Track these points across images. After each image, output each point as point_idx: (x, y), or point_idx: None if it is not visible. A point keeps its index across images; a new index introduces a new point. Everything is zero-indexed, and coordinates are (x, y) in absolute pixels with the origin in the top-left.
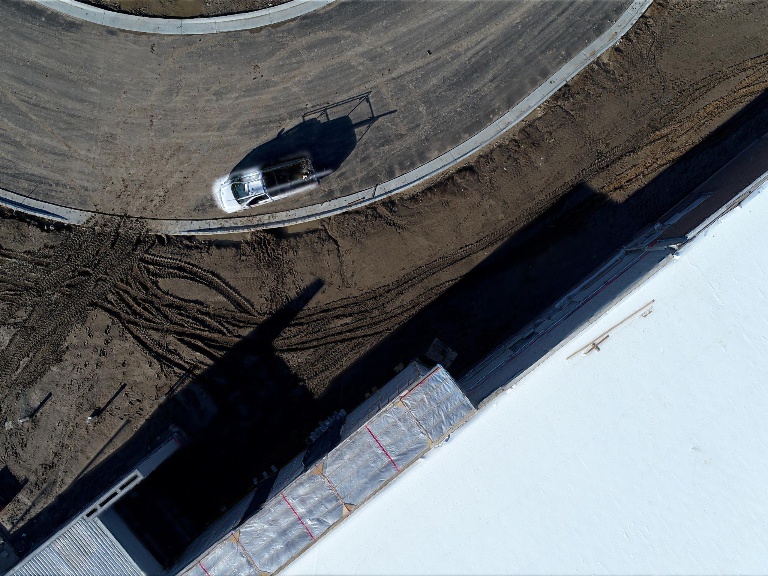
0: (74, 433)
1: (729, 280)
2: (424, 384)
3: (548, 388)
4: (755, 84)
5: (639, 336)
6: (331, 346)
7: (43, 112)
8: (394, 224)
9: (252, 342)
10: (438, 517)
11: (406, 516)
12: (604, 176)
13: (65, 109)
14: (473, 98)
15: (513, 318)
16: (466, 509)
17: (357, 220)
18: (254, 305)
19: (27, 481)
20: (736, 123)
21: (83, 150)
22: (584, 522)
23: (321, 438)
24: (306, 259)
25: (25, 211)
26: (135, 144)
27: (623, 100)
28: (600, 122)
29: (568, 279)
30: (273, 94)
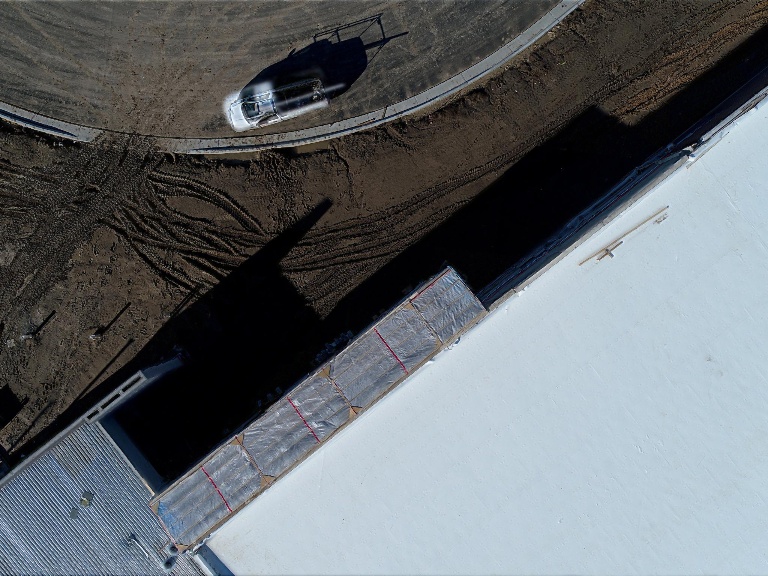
0: (77, 352)
1: (745, 187)
2: (434, 286)
3: (560, 295)
4: (767, 9)
5: (653, 243)
6: (339, 267)
7: (55, 30)
8: (404, 145)
9: (259, 262)
10: (447, 426)
11: (414, 425)
12: (616, 99)
13: (77, 27)
14: (484, 21)
15: (524, 241)
16: (476, 419)
17: (367, 141)
18: (262, 224)
19: (28, 400)
20: (749, 48)
21: (94, 68)
22: (597, 435)
23: None
24: (315, 179)
25: (34, 127)
26: (146, 62)
27: (635, 24)
28: (612, 45)
29: (579, 202)
30: (285, 15)
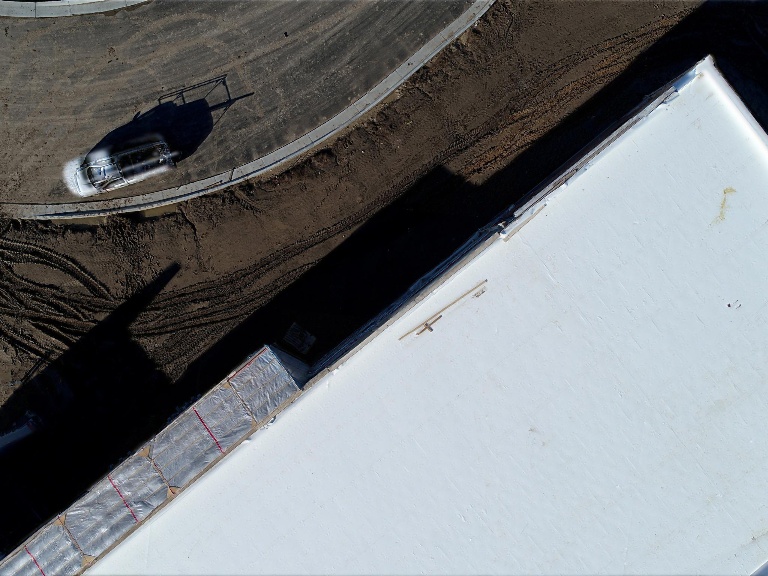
0: None
1: (563, 259)
2: (251, 365)
3: (381, 369)
4: (613, 65)
5: (473, 316)
6: (188, 331)
7: None
8: (251, 207)
9: (108, 327)
10: (271, 500)
11: (239, 499)
12: (462, 158)
13: None
14: (331, 80)
15: (372, 302)
16: (300, 492)
17: (214, 204)
18: (110, 290)
19: None
20: (595, 104)
21: None
22: (421, 505)
23: None
24: (162, 243)
25: None
26: None
27: (481, 82)
28: (458, 104)
29: (427, 262)
30: (129, 77)
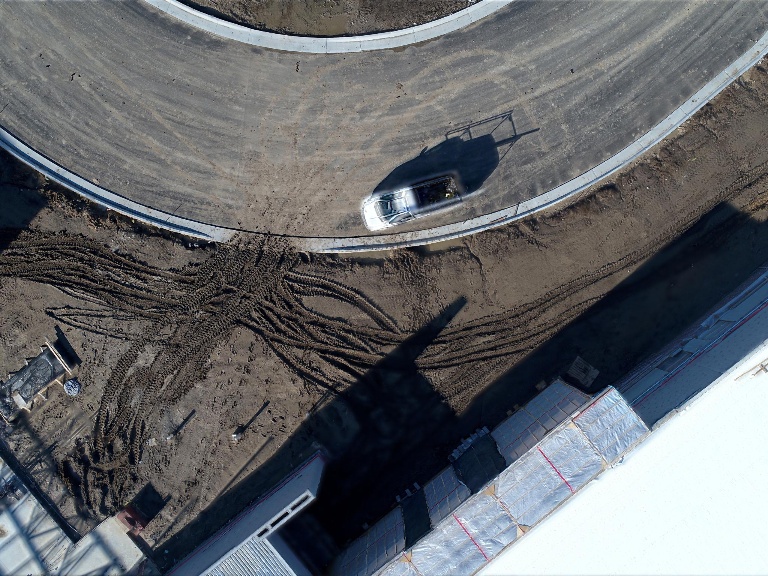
0: (217, 450)
1: None
2: (596, 405)
3: (716, 409)
4: None
5: None
6: (473, 364)
7: (188, 130)
8: (536, 242)
9: (395, 360)
10: (604, 537)
11: (573, 536)
12: (746, 195)
13: (210, 127)
14: (615, 117)
15: (655, 336)
16: (632, 529)
17: (499, 238)
18: (397, 323)
19: (170, 498)
20: None
21: (227, 168)
22: (749, 543)
23: (465, 456)
24: (449, 277)
25: (170, 229)
26: (279, 162)
27: (766, 119)
28: (743, 141)
29: (710, 297)
30: (416, 112)
